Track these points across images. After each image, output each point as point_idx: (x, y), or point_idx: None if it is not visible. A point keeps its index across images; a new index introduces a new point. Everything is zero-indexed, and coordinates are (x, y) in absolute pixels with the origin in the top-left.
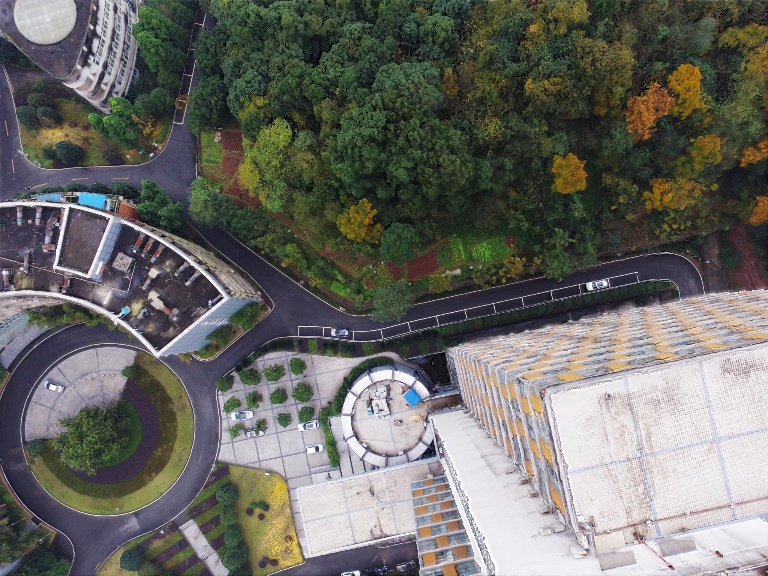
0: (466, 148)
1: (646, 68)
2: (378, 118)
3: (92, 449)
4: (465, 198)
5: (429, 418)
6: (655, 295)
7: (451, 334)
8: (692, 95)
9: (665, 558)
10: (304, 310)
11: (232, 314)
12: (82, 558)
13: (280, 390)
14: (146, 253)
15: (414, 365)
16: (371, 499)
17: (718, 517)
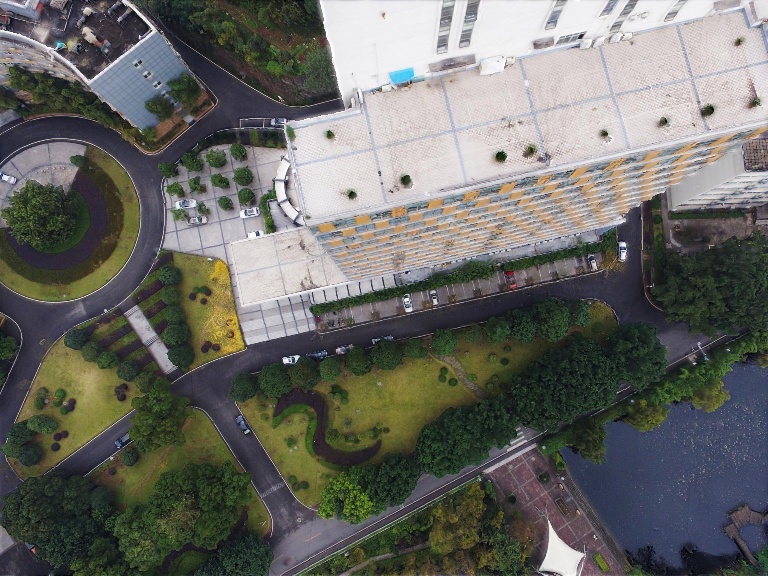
0: None
1: None
2: None
3: (36, 215)
4: None
5: None
6: None
7: None
8: None
9: None
10: (246, 104)
11: (169, 79)
12: (29, 343)
13: None
14: None
15: None
16: (301, 252)
17: None
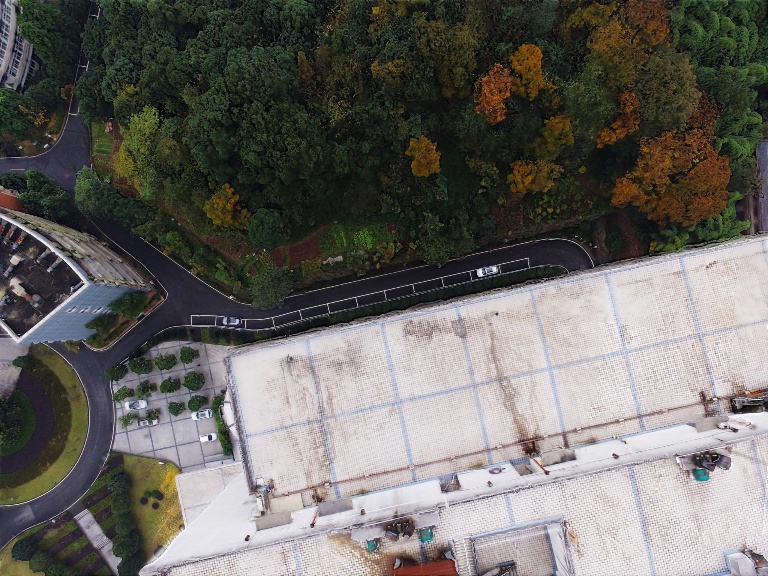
0: (316, 131)
1: (497, 50)
2: (220, 101)
3: None
4: (329, 183)
5: None
6: None
7: None
8: (534, 75)
9: (318, 517)
10: (197, 299)
11: (110, 302)
12: None
13: (174, 379)
14: (8, 240)
15: None
16: None
17: (397, 479)
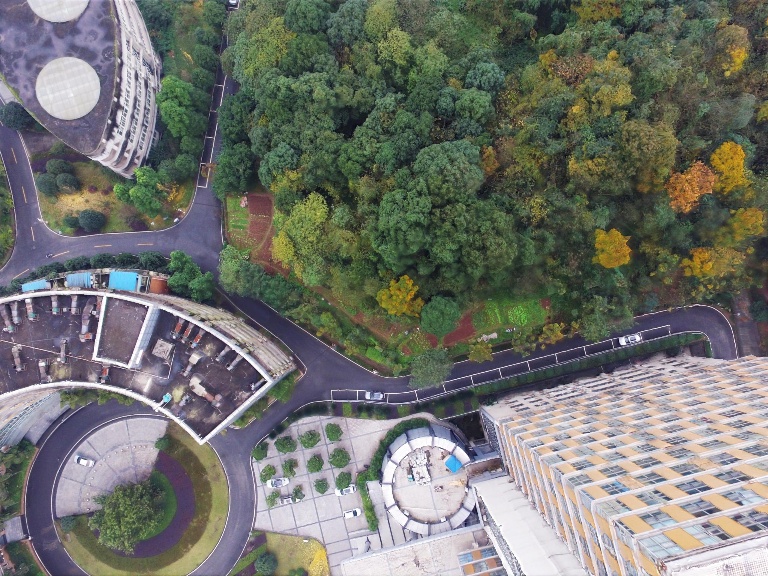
0: (510, 228)
1: (686, 142)
2: (424, 204)
3: (130, 529)
4: None
5: (472, 486)
6: (685, 345)
7: (486, 393)
8: (735, 172)
9: None
10: (337, 373)
11: (270, 388)
12: None
13: (315, 455)
14: (186, 339)
15: (448, 423)
16: (416, 570)
17: None
